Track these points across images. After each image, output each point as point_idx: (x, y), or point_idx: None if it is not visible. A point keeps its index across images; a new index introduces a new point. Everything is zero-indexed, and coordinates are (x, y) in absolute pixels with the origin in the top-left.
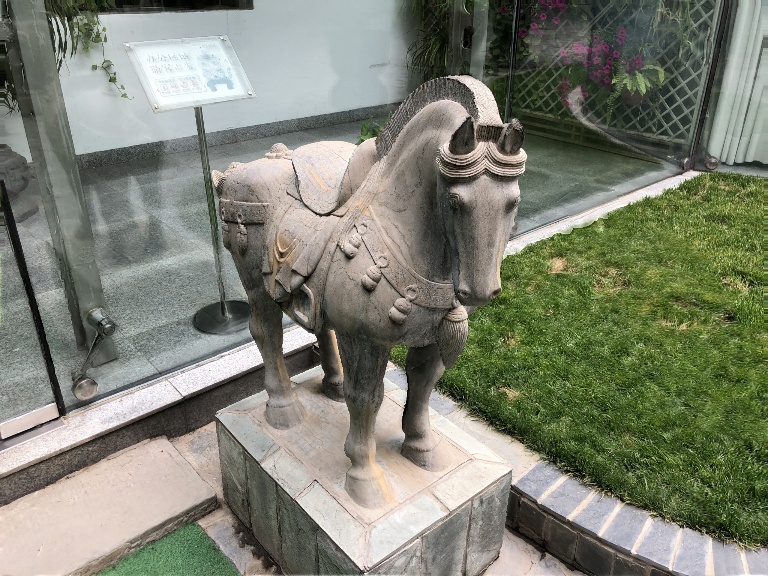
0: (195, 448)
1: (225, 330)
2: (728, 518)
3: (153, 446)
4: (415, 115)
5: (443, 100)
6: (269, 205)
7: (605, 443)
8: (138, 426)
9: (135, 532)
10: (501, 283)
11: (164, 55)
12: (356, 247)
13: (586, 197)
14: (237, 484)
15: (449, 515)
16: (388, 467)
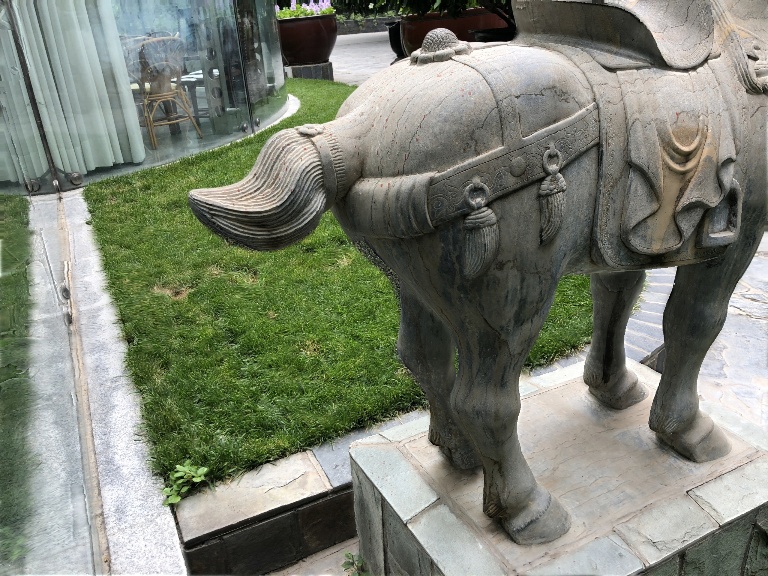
0: None
1: None
2: None
3: None
4: None
5: None
6: (601, 103)
7: None
8: None
9: None
10: (181, 328)
11: None
12: None
13: None
14: None
15: None
16: None
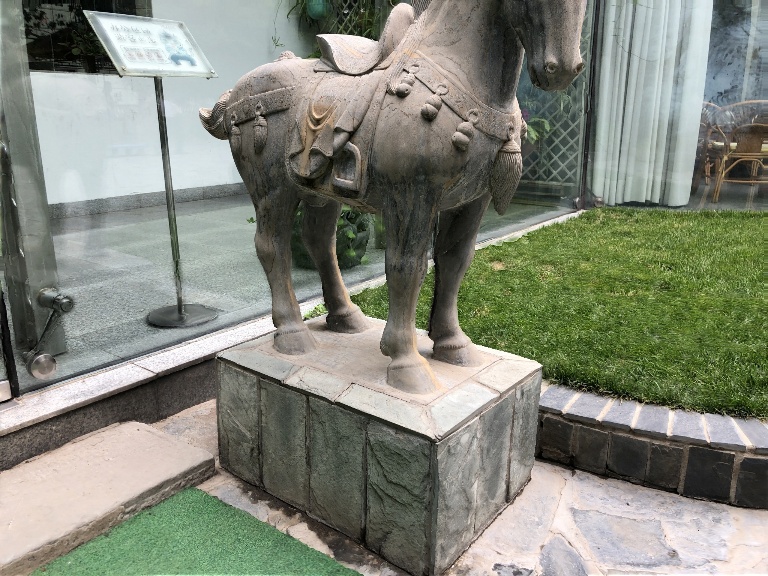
0: (172, 431)
1: None
2: (741, 398)
3: (126, 427)
4: None
5: None
6: (295, 87)
7: None
8: (107, 405)
9: (128, 495)
10: None
11: (127, 27)
12: (410, 84)
13: (503, 227)
14: (245, 431)
15: (499, 398)
16: None
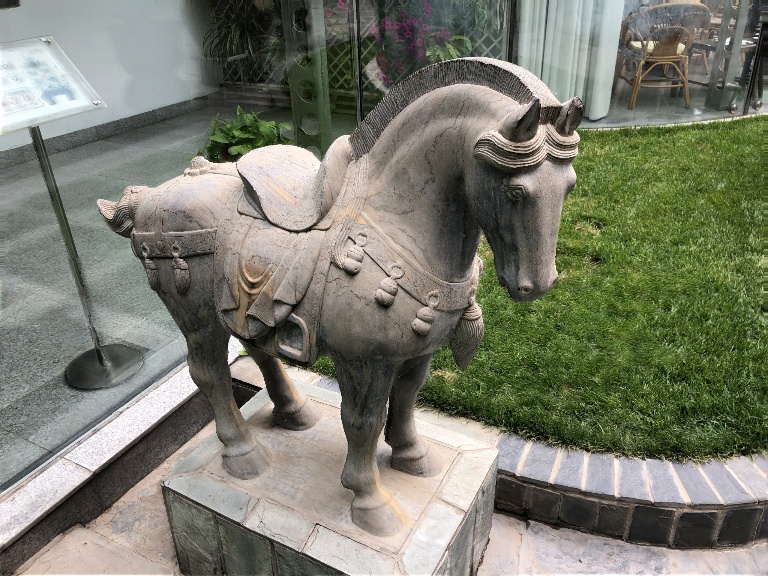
0: (121, 526)
1: (110, 381)
2: (678, 440)
3: (71, 540)
4: (409, 105)
5: (456, 85)
6: (217, 230)
7: (551, 401)
8: (46, 523)
9: None
10: None
11: None
12: (359, 261)
13: None
14: (205, 554)
15: (464, 516)
16: (386, 486)
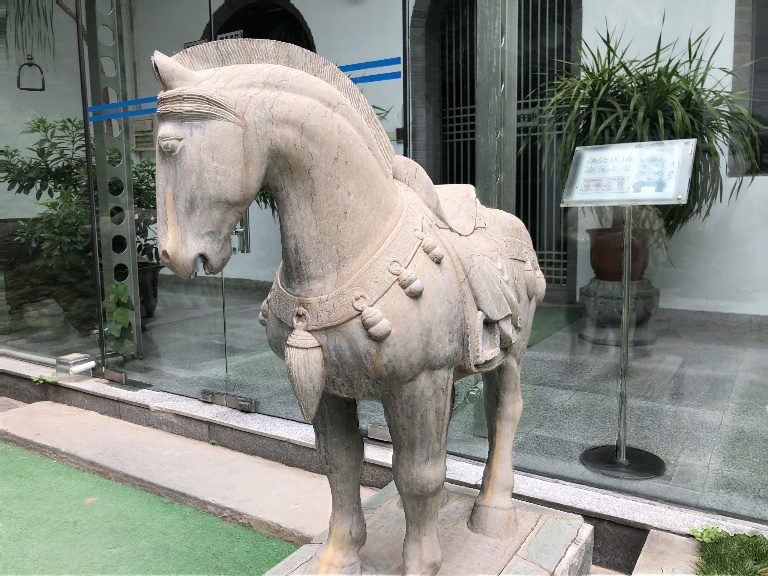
0: None
1: (600, 469)
2: None
3: None
4: None
5: None
6: None
7: None
8: None
9: None
10: None
11: (607, 158)
12: None
13: None
14: None
15: None
16: None
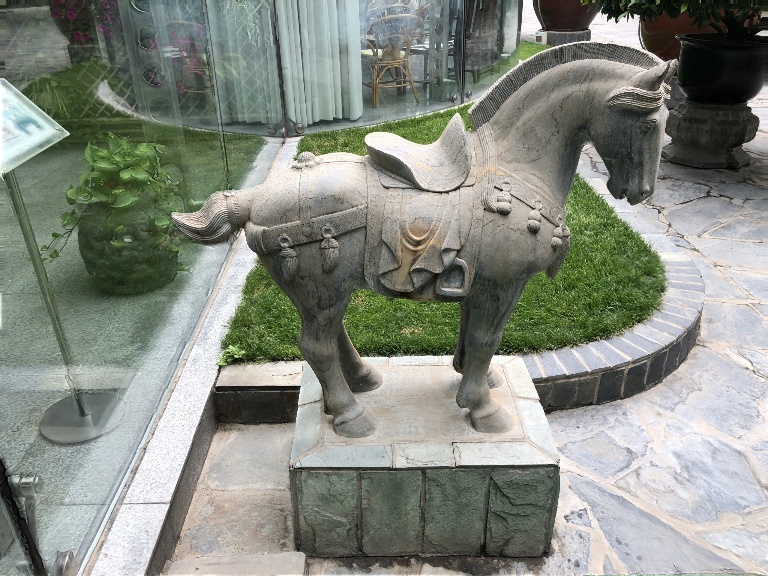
0: (207, 548)
1: (104, 427)
2: (602, 324)
3: (180, 573)
4: (530, 80)
5: (576, 61)
6: (369, 205)
7: None
8: (152, 564)
9: None
10: None
11: None
12: (510, 202)
13: (246, 177)
14: (339, 519)
15: None
16: None
